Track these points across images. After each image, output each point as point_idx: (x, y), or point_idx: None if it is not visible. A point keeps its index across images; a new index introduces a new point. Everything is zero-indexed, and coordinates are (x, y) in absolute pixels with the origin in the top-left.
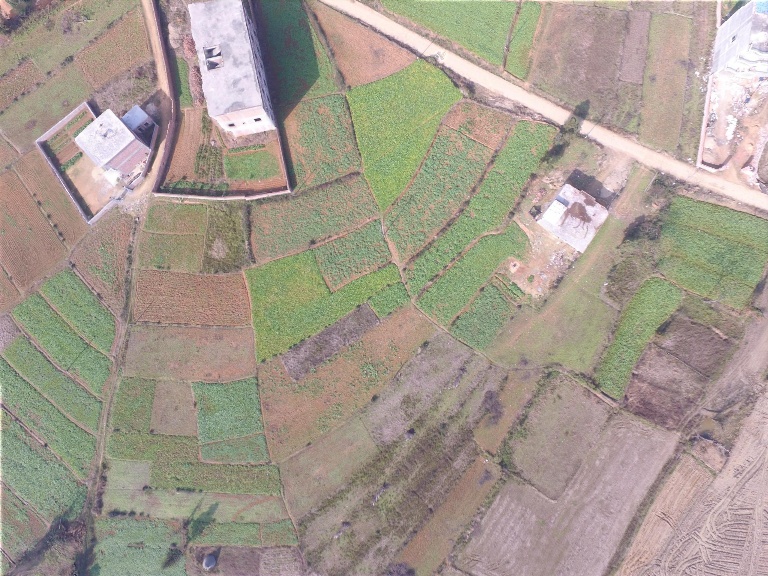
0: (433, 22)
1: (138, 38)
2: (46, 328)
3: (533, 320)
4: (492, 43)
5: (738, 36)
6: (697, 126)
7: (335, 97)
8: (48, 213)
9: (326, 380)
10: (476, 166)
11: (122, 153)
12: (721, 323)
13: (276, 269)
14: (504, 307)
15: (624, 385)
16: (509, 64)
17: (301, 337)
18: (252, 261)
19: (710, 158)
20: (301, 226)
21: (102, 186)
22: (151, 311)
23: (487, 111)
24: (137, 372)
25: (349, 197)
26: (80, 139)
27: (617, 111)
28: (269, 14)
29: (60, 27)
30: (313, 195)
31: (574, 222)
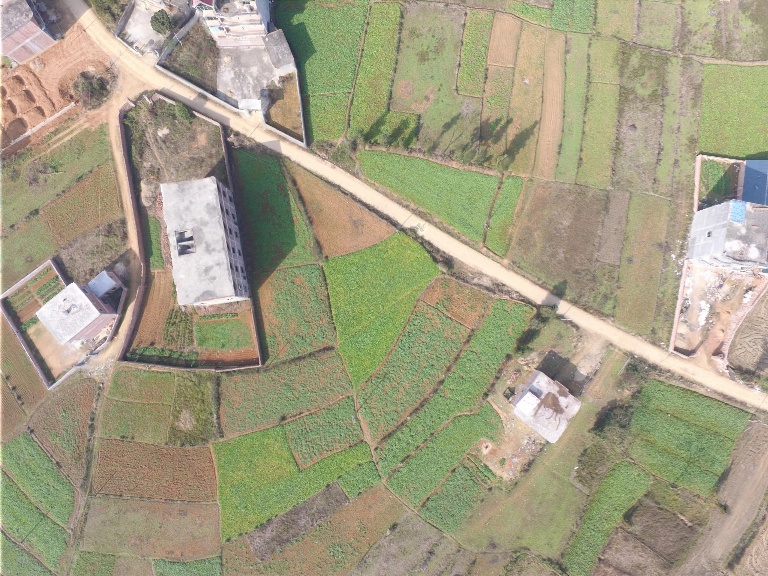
0: (414, 194)
1: (108, 194)
2: (0, 497)
3: (503, 503)
4: (473, 218)
5: (713, 235)
6: (671, 310)
7: (312, 267)
8: (6, 374)
9: (292, 561)
10: (452, 345)
11: (86, 327)
12: (686, 510)
13: (245, 444)
14: (475, 489)
15: (590, 569)
16: (489, 240)
17: (268, 516)
18: (220, 436)
19: (682, 344)
20: (272, 401)
21: (65, 348)
22: (113, 483)
23: (465, 288)
24: (96, 547)
25: (322, 372)
26: (42, 314)
27: (594, 292)
28: (247, 176)
29: (26, 178)
30: (285, 369)
31: (547, 413)
